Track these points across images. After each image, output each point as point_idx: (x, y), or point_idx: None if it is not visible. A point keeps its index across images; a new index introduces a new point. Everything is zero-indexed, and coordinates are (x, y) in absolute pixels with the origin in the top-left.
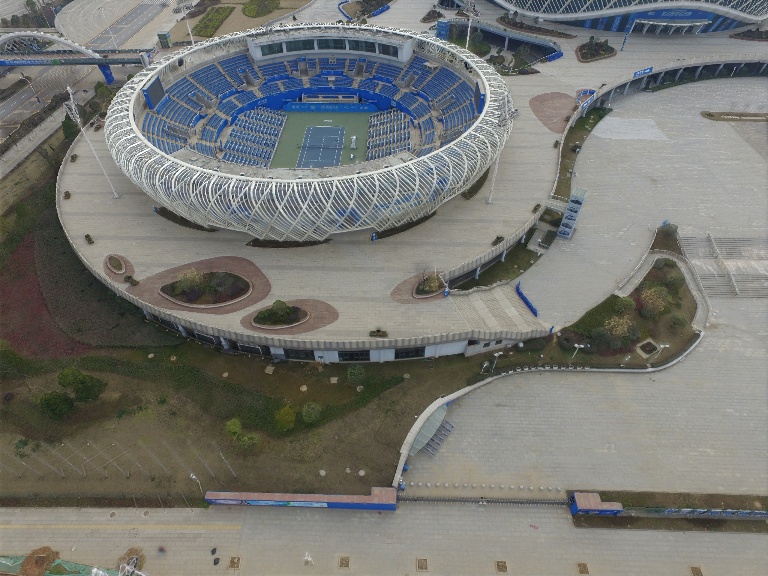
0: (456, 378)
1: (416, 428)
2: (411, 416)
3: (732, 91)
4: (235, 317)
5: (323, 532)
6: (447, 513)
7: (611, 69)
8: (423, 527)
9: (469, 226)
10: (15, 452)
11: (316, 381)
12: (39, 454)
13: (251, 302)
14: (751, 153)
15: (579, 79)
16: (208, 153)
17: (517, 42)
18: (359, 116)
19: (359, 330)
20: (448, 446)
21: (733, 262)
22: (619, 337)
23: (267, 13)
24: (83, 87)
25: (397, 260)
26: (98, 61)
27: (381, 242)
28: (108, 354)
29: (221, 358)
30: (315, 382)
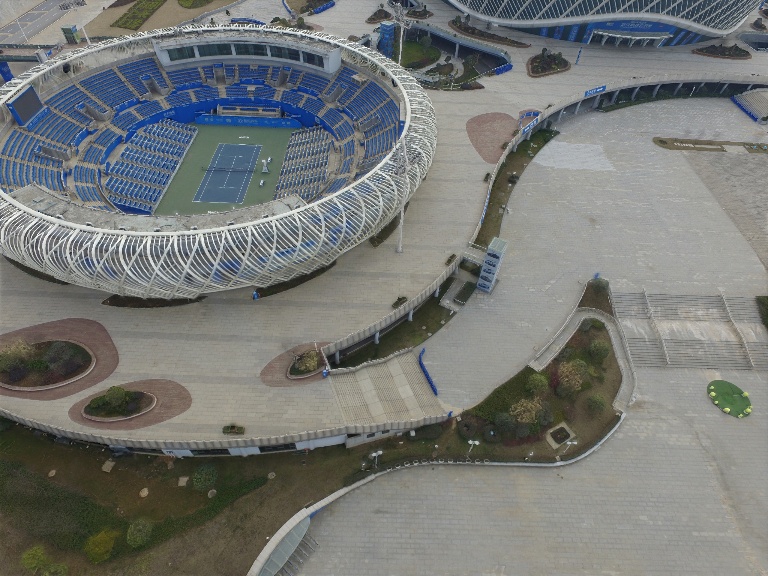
0: (331, 477)
1: (265, 554)
2: (262, 537)
3: (689, 114)
4: (64, 404)
5: None
6: None
7: (562, 86)
8: None
9: (370, 281)
10: None
11: (161, 482)
12: None
13: (89, 383)
14: (701, 189)
15: (525, 97)
16: (88, 179)
17: (468, 49)
18: (280, 132)
19: (212, 424)
20: (308, 570)
21: (667, 324)
22: (527, 423)
23: (204, 4)
24: None
25: (278, 326)
26: None
27: (264, 301)
28: None
29: (52, 450)
30: (160, 484)
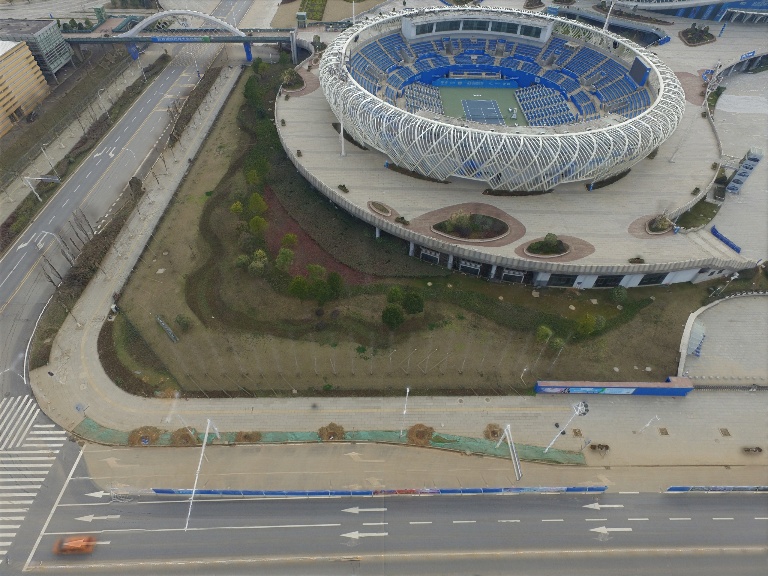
0: (692, 300)
1: (687, 333)
2: (679, 325)
3: None
4: (509, 249)
5: (636, 411)
6: (727, 397)
7: (718, 52)
8: (713, 407)
9: (664, 180)
10: (359, 356)
11: (580, 302)
12: (379, 357)
13: (515, 238)
14: None
15: (695, 61)
16: None
17: (616, 28)
18: (503, 91)
19: (618, 258)
20: (705, 351)
21: None
22: None
23: None
24: None
25: (619, 206)
26: (246, 39)
27: (597, 192)
28: (394, 282)
29: (490, 286)
30: (579, 303)
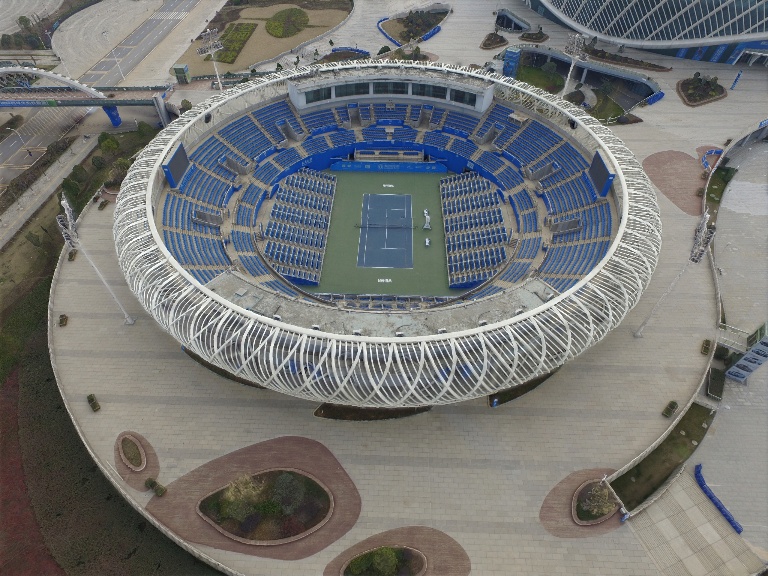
0: None
1: None
2: None
3: None
4: (315, 566)
5: None
6: None
7: (728, 116)
8: None
9: (621, 379)
10: None
11: None
12: None
13: (335, 533)
14: None
15: (694, 131)
16: (247, 246)
17: (597, 74)
18: (425, 178)
19: None
20: None
21: None
22: None
23: (295, 32)
24: (84, 131)
25: (535, 445)
26: (102, 102)
27: (505, 409)
28: None
29: None
30: None
